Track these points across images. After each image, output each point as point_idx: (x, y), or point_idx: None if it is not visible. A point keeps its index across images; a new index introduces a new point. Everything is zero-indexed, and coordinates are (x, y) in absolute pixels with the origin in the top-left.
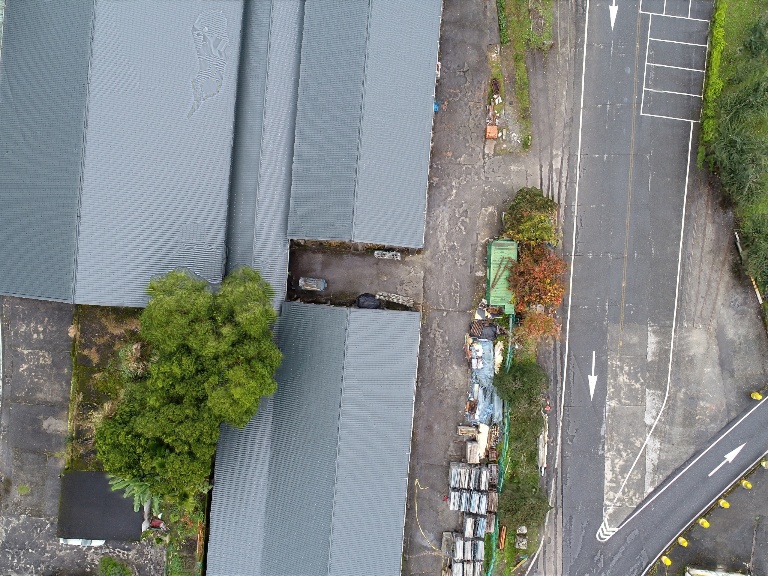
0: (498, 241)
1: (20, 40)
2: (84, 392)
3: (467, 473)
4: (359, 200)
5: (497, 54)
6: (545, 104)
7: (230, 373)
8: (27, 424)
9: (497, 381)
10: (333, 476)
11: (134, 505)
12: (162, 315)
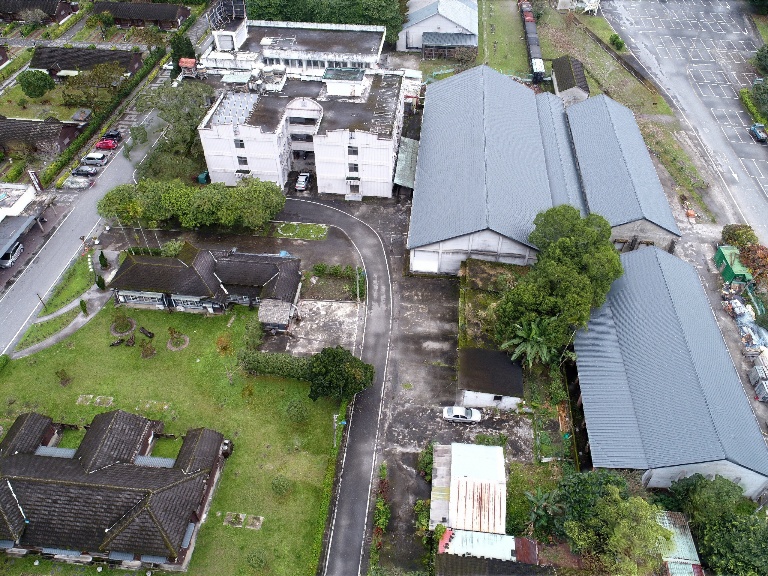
0: (723, 246)
1: (431, 156)
2: (471, 303)
3: (767, 369)
4: (641, 203)
5: (678, 188)
6: (716, 207)
7: (601, 248)
8: (411, 345)
9: (759, 319)
10: (679, 326)
11: (527, 353)
12: (560, 211)
